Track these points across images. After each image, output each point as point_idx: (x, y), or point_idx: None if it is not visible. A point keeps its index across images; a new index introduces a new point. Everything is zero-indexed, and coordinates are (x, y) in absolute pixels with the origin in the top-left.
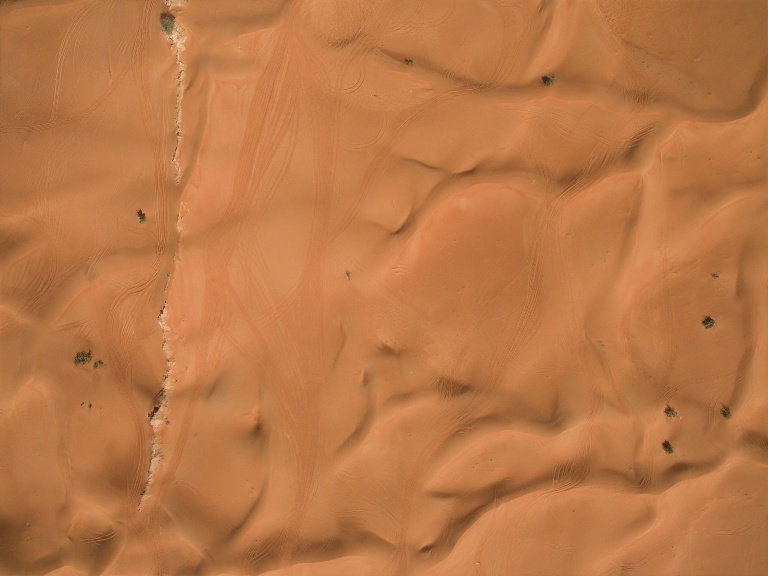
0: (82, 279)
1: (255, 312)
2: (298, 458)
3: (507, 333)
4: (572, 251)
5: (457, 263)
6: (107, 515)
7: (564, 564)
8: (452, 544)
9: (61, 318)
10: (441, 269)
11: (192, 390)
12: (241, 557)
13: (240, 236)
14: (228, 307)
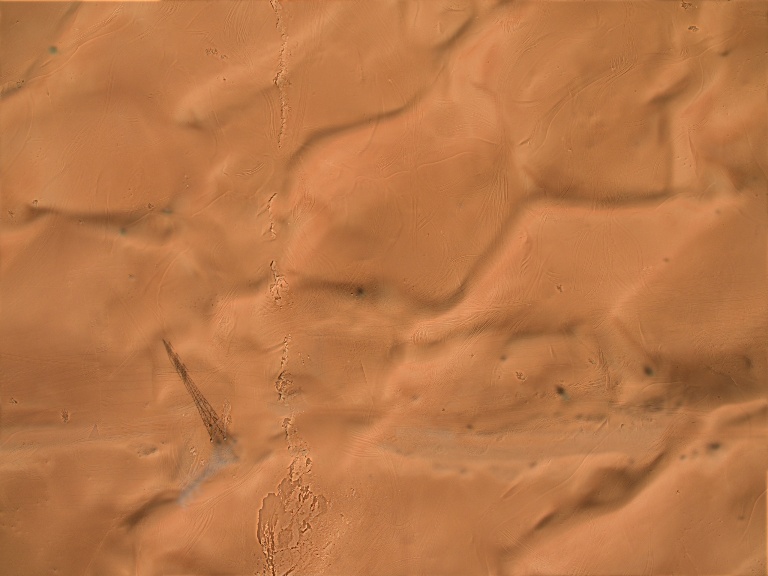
0: (201, 1)
1: None
2: (402, 95)
3: None
4: None
5: None
6: (254, 153)
7: (641, 136)
8: (545, 130)
9: (189, 27)
10: None
11: (304, 63)
12: (373, 167)
13: None
14: None
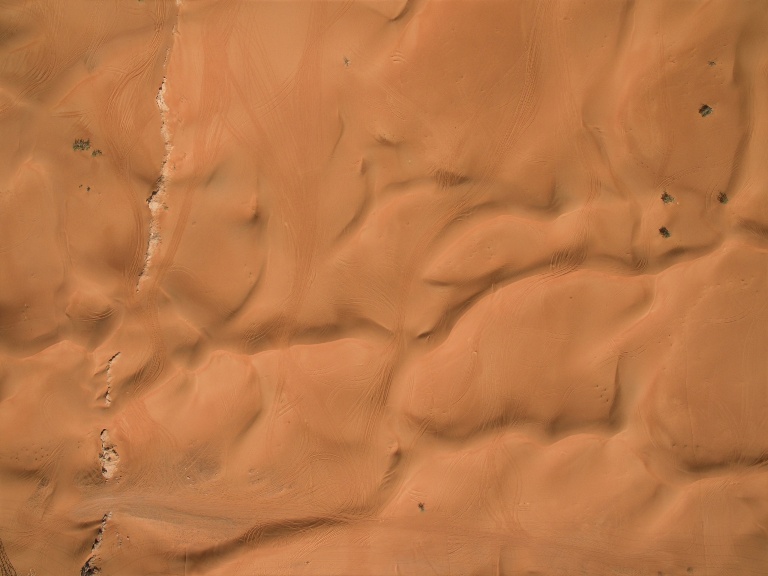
0: (81, 69)
1: (254, 99)
2: (296, 246)
3: (505, 122)
4: (570, 36)
5: (455, 53)
6: (105, 294)
7: (561, 352)
8: (449, 328)
9: (60, 105)
10: (439, 59)
11: (190, 179)
12: (239, 337)
13: (239, 16)
14: (227, 92)
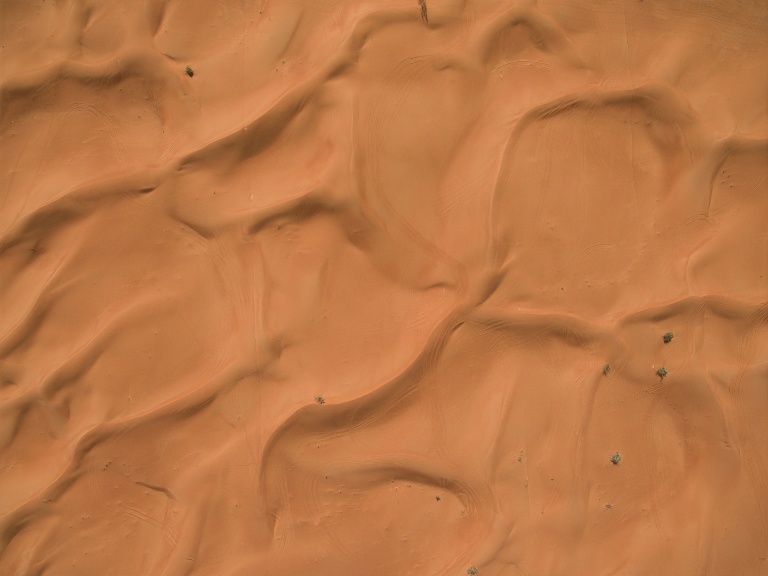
0: None
1: None
2: None
3: None
4: (759, 541)
5: None
6: None
7: None
8: None
9: None
10: None
11: None
12: None
13: None
14: None
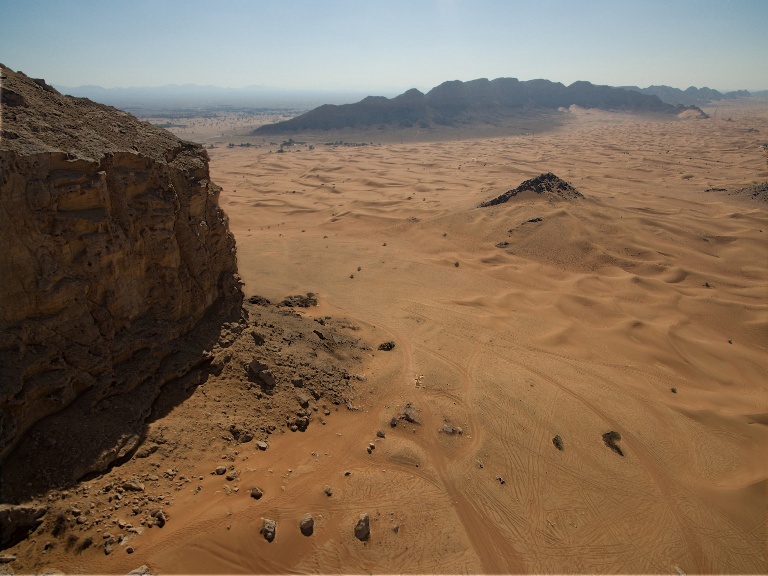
0: None
1: None
2: None
3: None
4: None
5: None
6: None
7: None
8: None
9: None
10: None
11: None
12: None
13: None
14: None
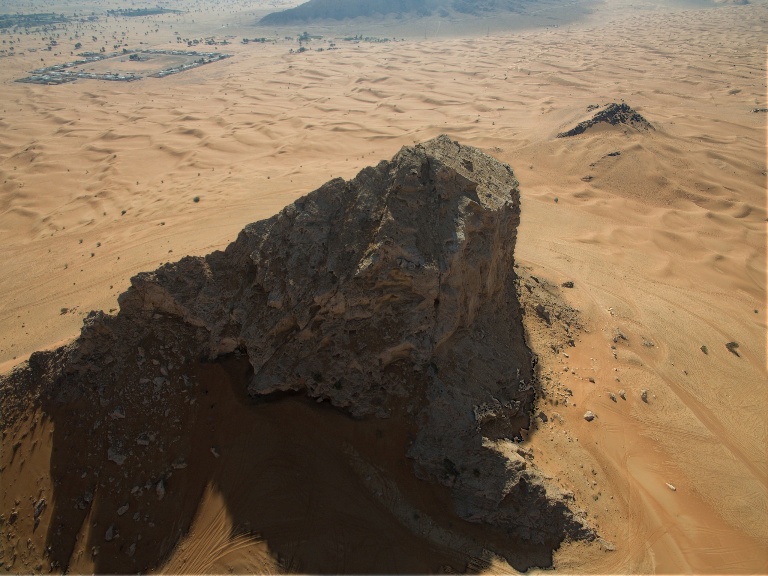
0: None
1: None
2: None
3: None
4: None
5: None
6: None
7: None
8: None
9: None
10: None
11: None
12: None
13: None
14: None
